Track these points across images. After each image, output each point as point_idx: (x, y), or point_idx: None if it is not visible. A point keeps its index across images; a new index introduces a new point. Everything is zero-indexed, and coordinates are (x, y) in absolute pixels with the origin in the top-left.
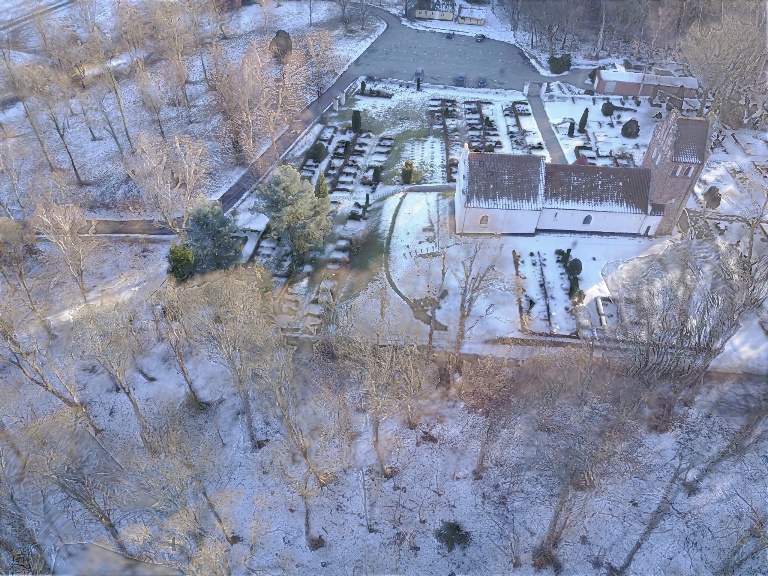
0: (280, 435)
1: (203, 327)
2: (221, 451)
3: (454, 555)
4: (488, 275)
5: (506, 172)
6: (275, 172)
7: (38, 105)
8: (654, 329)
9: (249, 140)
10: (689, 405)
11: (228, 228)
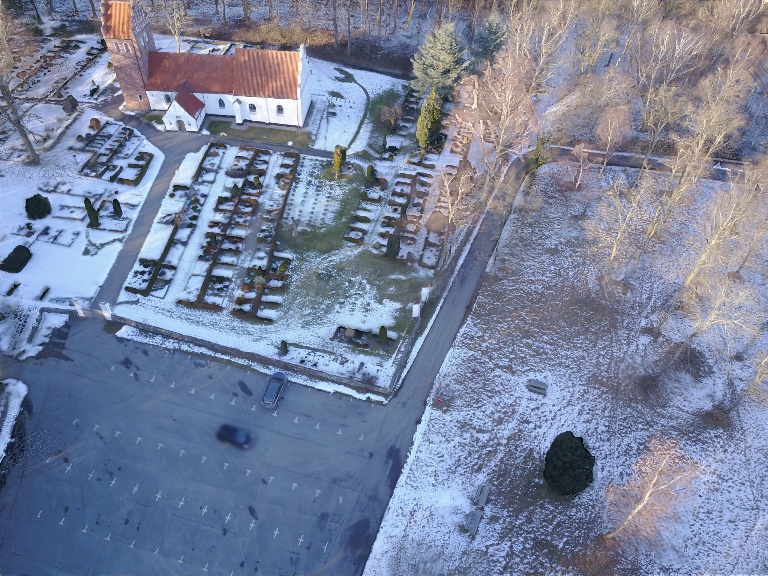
0: None
1: None
2: None
3: None
4: None
5: None
6: None
7: None
8: None
9: None
10: None
11: None
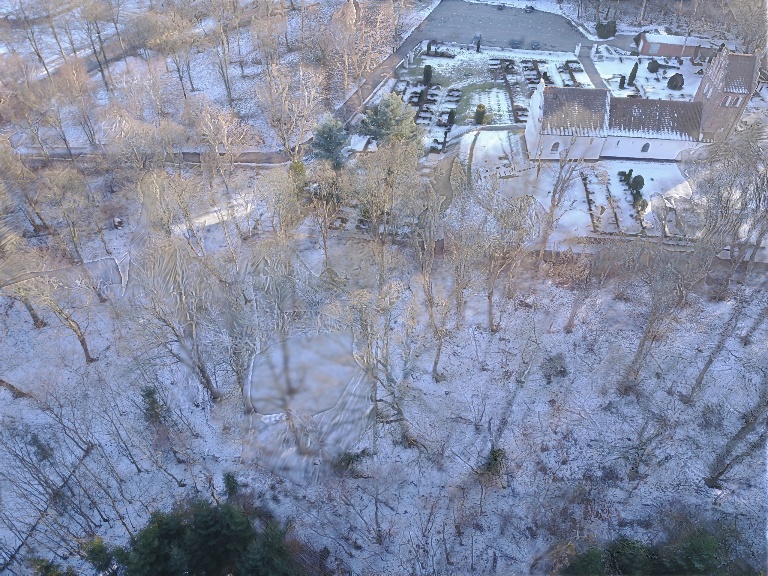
0: (410, 292)
1: (361, 191)
2: None
3: (553, 386)
4: (579, 165)
5: (576, 104)
6: (385, 96)
7: (165, 49)
8: (723, 193)
9: (344, 82)
10: (742, 282)
11: (347, 141)
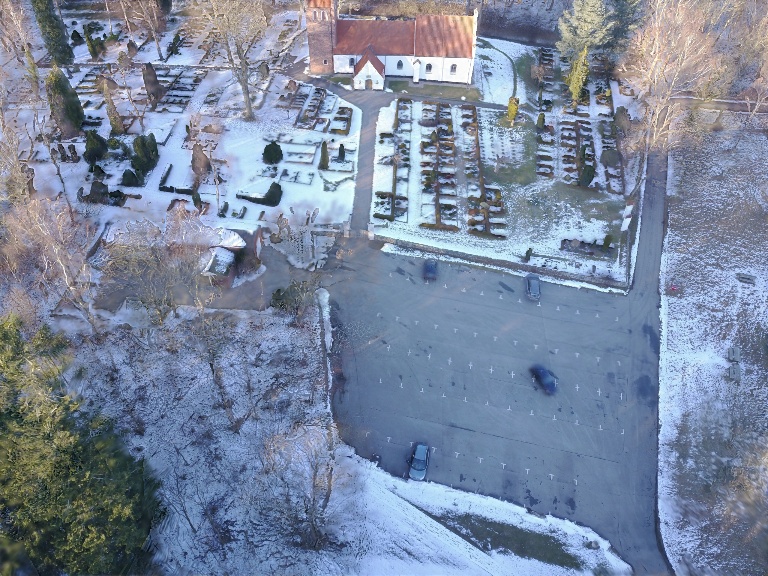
0: None
1: None
2: (563, 7)
3: None
4: None
5: None
6: None
7: None
8: None
9: None
10: None
11: None
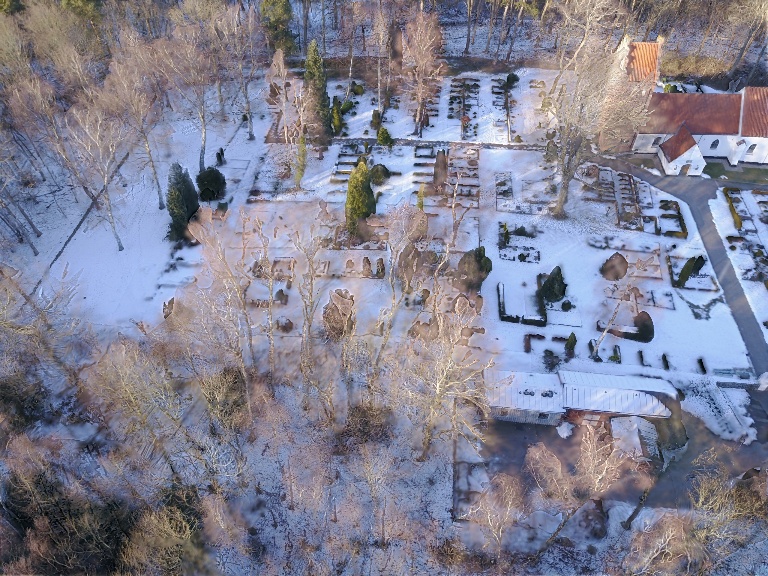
0: None
1: None
2: None
3: (699, 41)
4: None
5: None
6: None
7: None
8: None
9: None
10: None
11: None
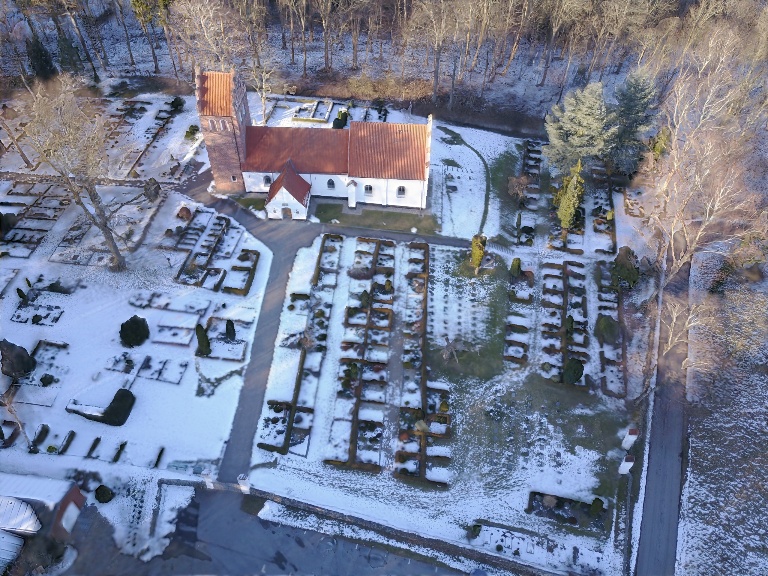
0: None
1: None
2: None
3: None
4: None
5: None
6: None
7: None
8: None
9: None
10: None
11: None
